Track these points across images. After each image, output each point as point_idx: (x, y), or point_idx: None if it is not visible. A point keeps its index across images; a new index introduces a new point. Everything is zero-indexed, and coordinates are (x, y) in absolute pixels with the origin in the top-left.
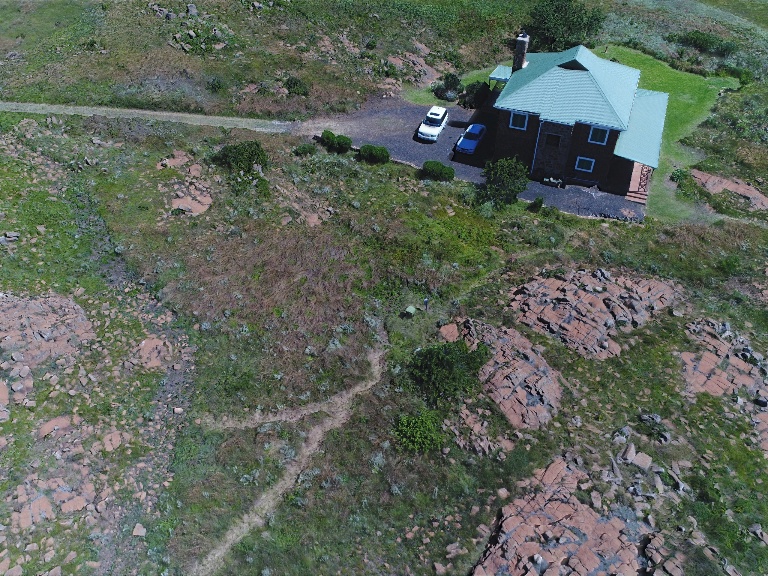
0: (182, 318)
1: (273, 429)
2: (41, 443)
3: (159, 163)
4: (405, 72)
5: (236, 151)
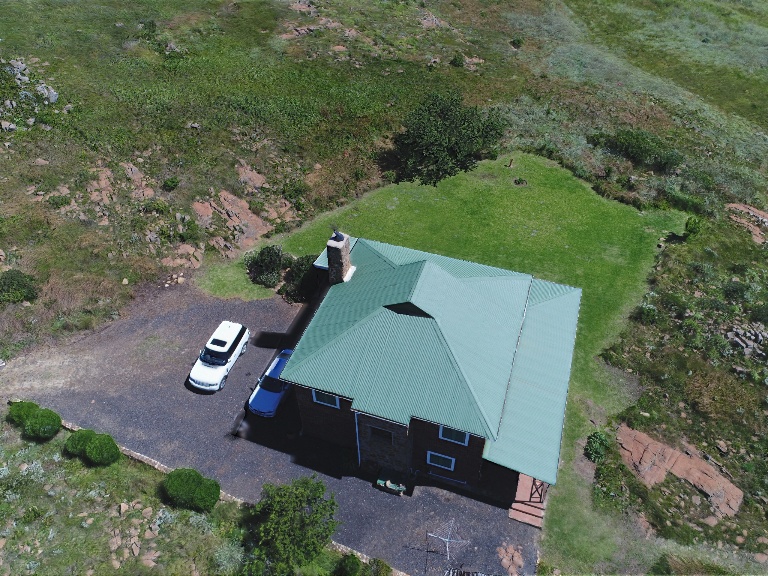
0: None
1: None
2: None
3: None
4: (212, 231)
5: None
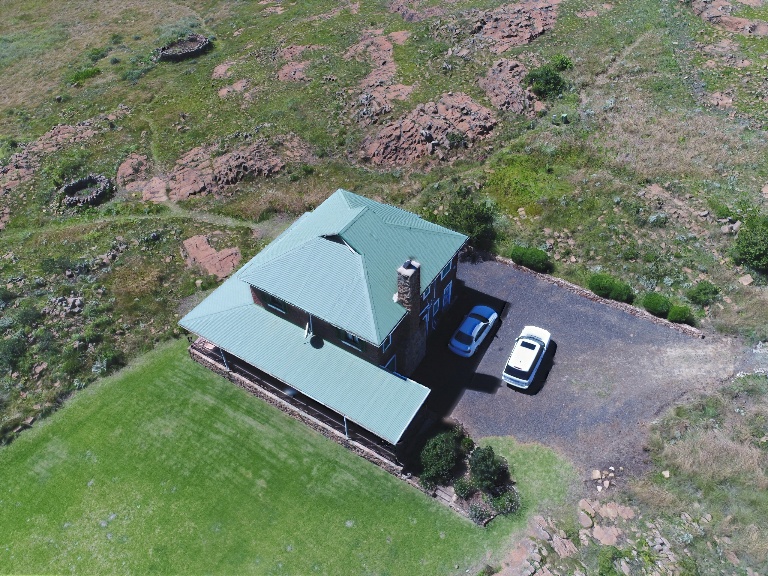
0: None
1: (633, 68)
2: (743, 58)
3: None
4: (576, 568)
5: None
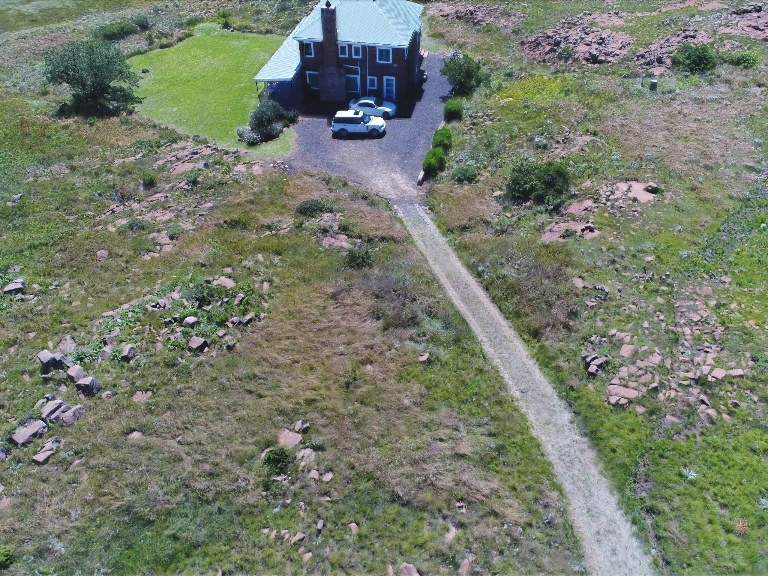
0: (762, 155)
1: None
2: None
3: (590, 235)
4: None
5: (555, 165)
